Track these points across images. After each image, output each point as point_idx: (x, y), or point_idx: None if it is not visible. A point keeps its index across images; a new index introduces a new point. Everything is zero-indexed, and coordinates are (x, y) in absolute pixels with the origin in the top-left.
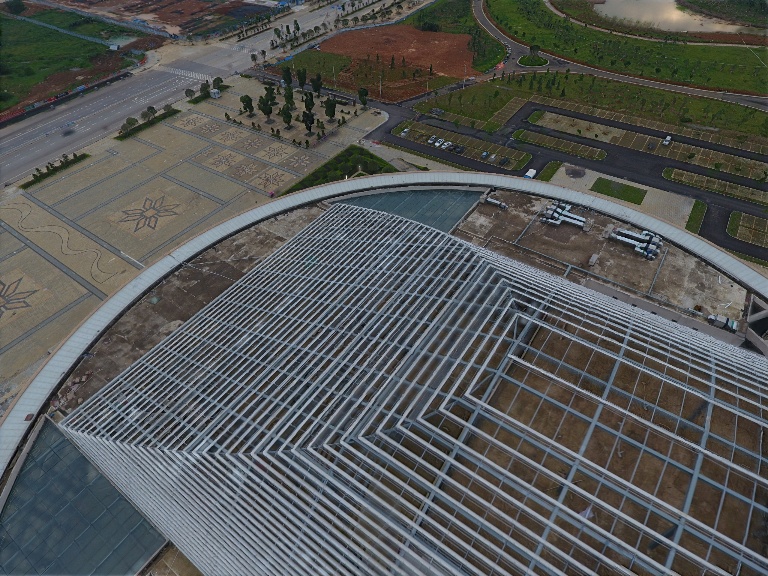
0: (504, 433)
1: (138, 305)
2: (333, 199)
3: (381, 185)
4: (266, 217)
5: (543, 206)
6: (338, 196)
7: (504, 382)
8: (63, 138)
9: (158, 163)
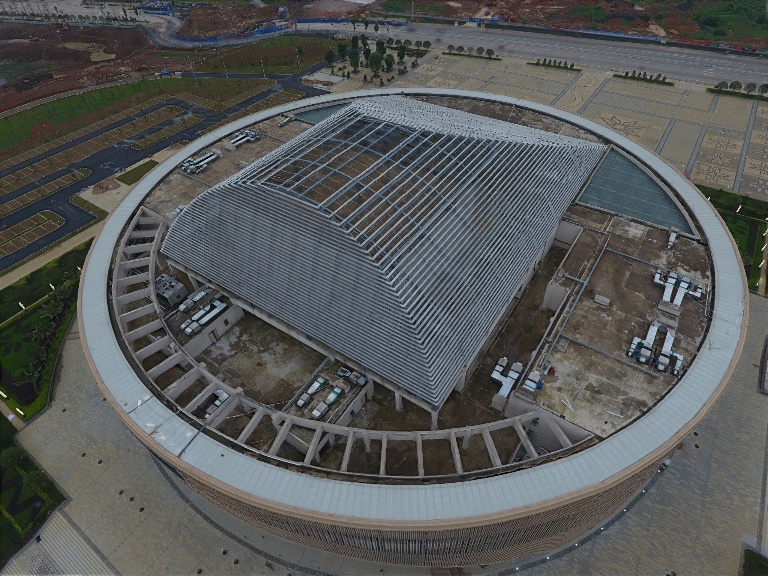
0: (344, 124)
1: (476, 101)
2: (619, 149)
3: (656, 169)
4: (577, 125)
5: (689, 276)
6: (626, 152)
7: (371, 122)
8: (687, 70)
9: (688, 115)
